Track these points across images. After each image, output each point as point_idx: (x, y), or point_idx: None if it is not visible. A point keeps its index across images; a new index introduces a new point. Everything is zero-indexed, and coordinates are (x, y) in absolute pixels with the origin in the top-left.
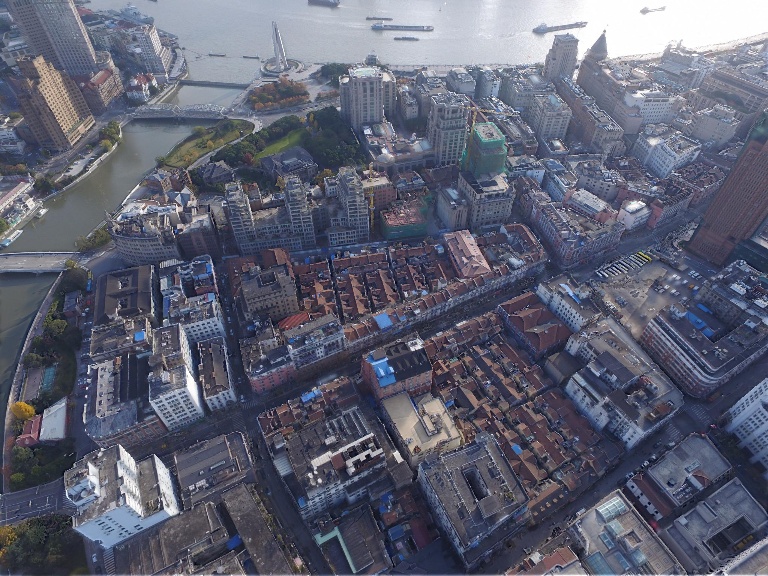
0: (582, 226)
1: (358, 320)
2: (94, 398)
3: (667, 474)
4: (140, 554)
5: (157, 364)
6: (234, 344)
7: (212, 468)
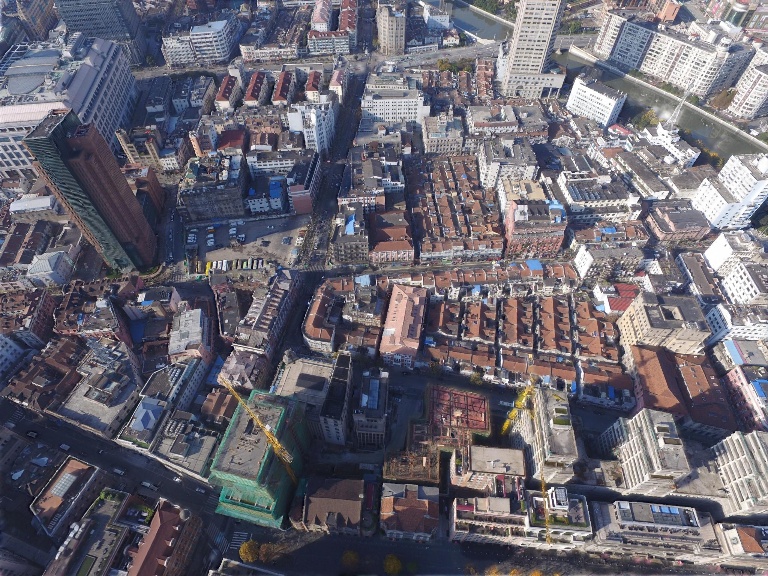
0: (239, 305)
1: None
2: None
3: (393, 139)
4: None
5: None
6: None
7: (679, 212)
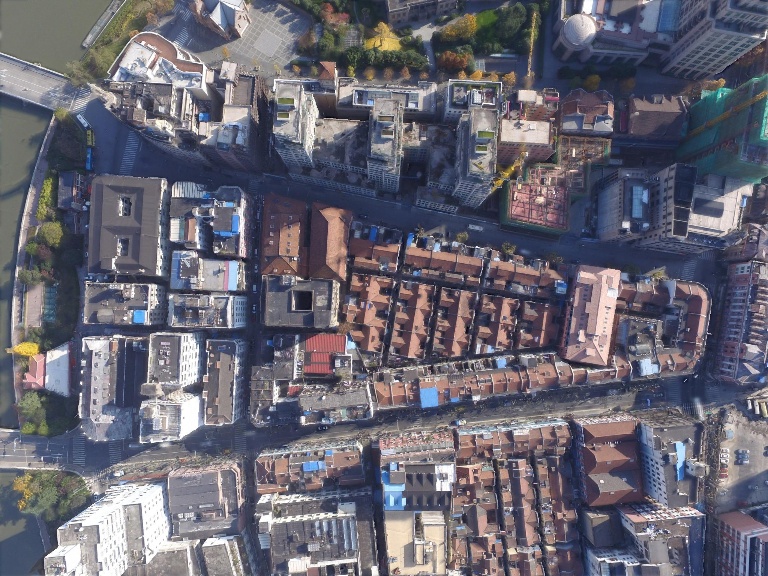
0: None
1: (403, 370)
2: (88, 393)
3: None
4: (129, 574)
5: (150, 396)
6: (254, 328)
7: (201, 507)
